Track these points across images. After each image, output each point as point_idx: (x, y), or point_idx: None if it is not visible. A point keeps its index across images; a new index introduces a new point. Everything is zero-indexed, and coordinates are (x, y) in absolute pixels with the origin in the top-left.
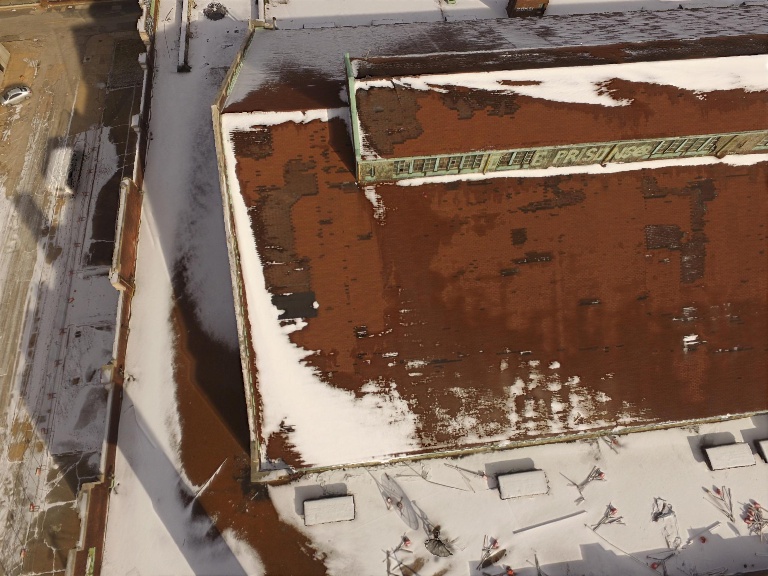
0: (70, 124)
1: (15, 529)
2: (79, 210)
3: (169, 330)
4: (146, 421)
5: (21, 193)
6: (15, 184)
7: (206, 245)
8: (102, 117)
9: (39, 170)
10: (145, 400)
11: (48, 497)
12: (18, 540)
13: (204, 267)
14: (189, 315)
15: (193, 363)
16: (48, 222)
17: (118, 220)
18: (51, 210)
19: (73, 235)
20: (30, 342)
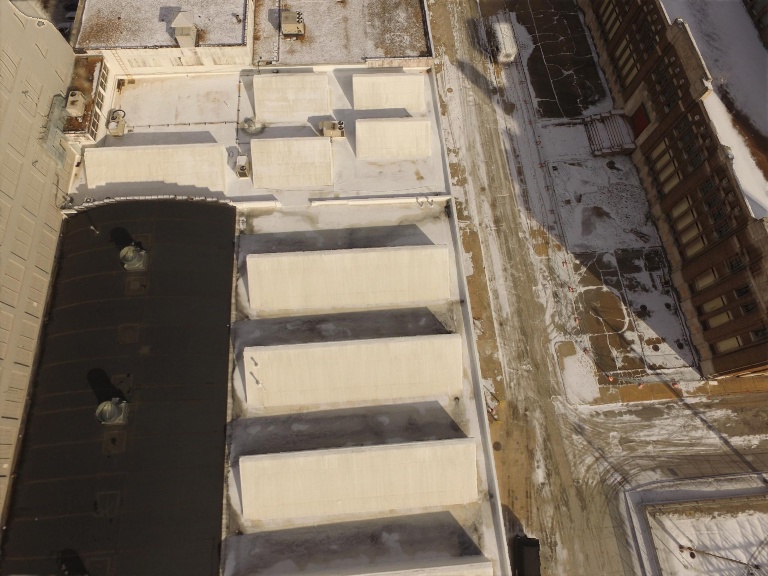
0: (480, 9)
1: (563, 303)
2: (517, 75)
3: (737, 134)
4: (752, 193)
5: (462, 60)
6: (454, 53)
7: (735, 77)
8: (505, 4)
9: (469, 43)
10: (744, 179)
11: (580, 283)
12: (569, 311)
13: (742, 92)
14: (747, 124)
15: (767, 157)
16: (494, 84)
17: (695, 45)
18: (492, 75)
19: (520, 94)
20: (518, 172)
